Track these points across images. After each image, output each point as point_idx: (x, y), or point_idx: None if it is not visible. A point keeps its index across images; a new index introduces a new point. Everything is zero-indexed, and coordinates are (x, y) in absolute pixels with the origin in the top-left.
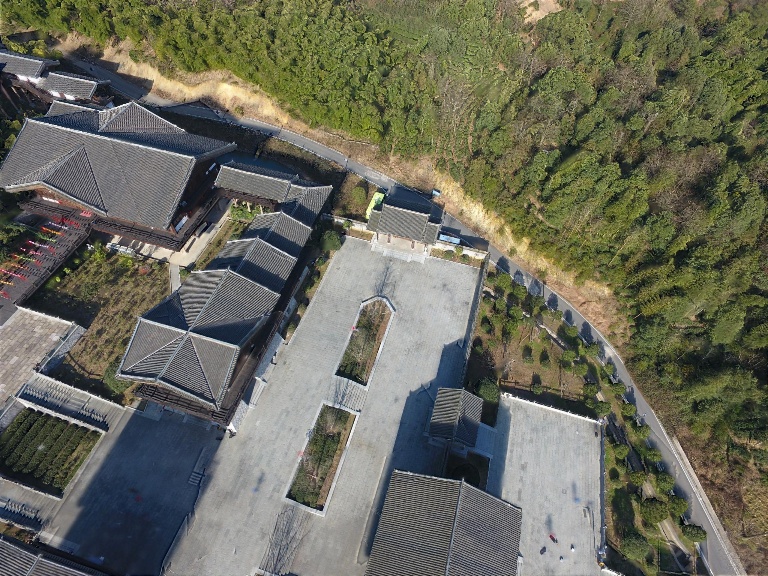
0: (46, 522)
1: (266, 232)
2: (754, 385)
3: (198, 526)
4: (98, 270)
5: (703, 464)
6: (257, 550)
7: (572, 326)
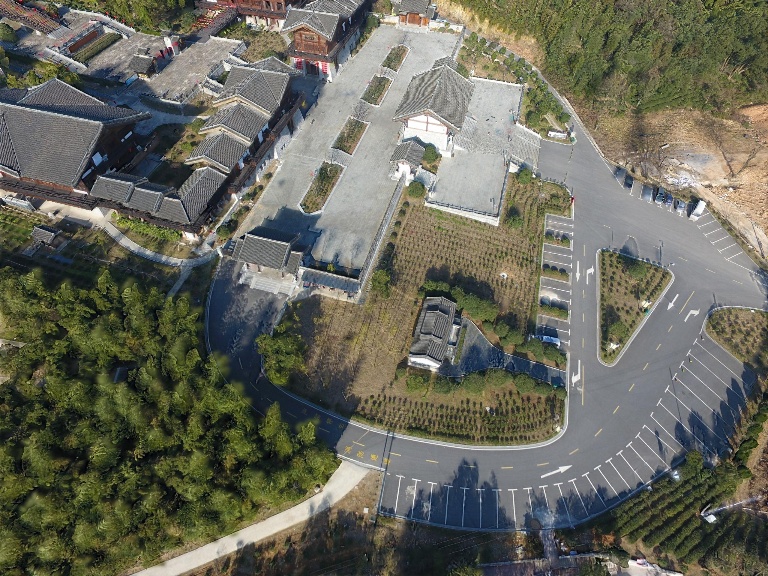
0: None
1: None
2: (605, 63)
3: (320, 105)
4: None
5: None
6: (349, 111)
7: (511, 53)
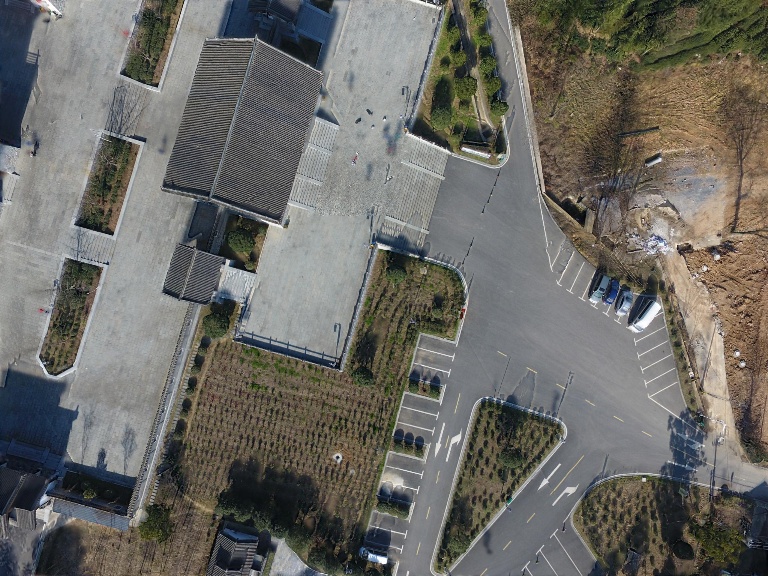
0: None
1: None
2: None
3: (44, 98)
4: None
5: (539, 55)
6: (100, 116)
7: None
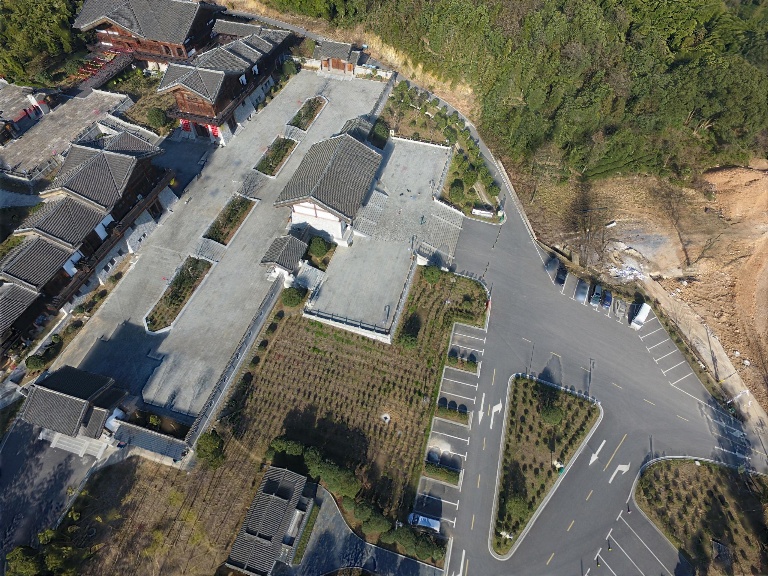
0: None
1: None
2: (545, 123)
3: (203, 178)
4: None
5: None
6: (236, 186)
7: (442, 107)
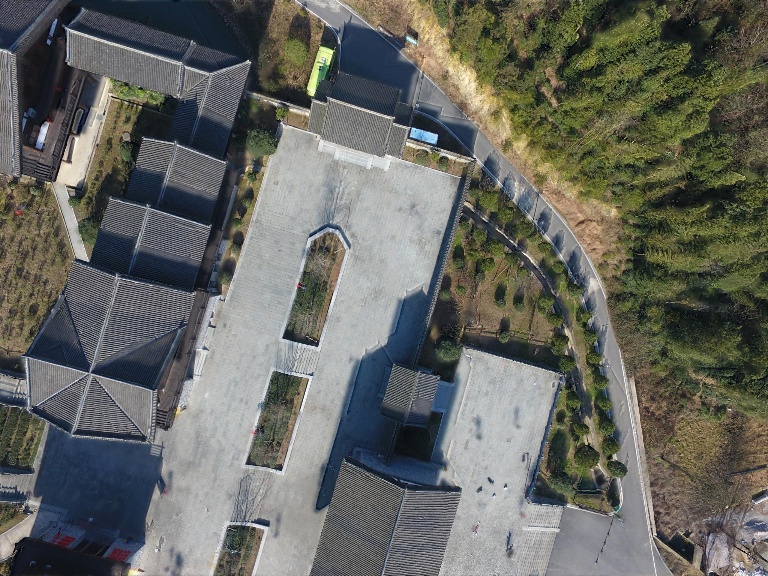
0: (28, 493)
1: (160, 182)
2: (735, 344)
3: (169, 491)
4: None
5: (651, 398)
6: (226, 508)
7: (559, 263)
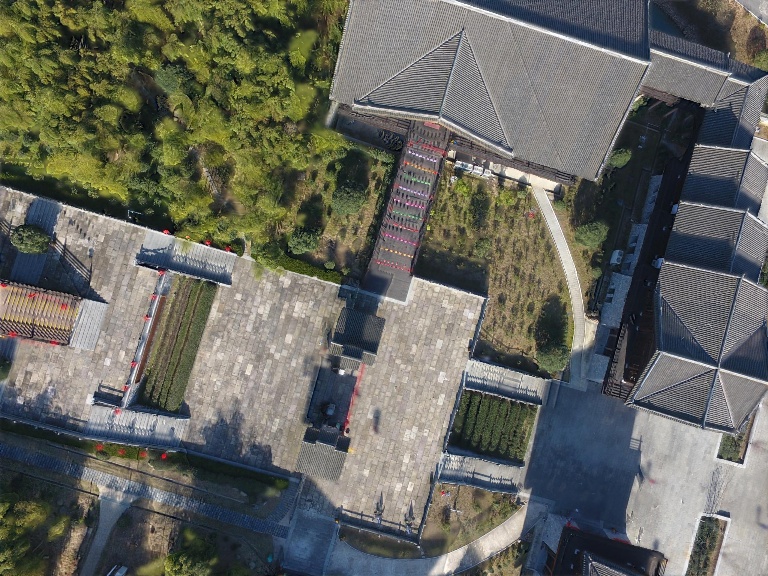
0: (520, 485)
1: (732, 187)
2: None
3: (648, 483)
4: (457, 204)
5: None
6: (700, 500)
7: None
